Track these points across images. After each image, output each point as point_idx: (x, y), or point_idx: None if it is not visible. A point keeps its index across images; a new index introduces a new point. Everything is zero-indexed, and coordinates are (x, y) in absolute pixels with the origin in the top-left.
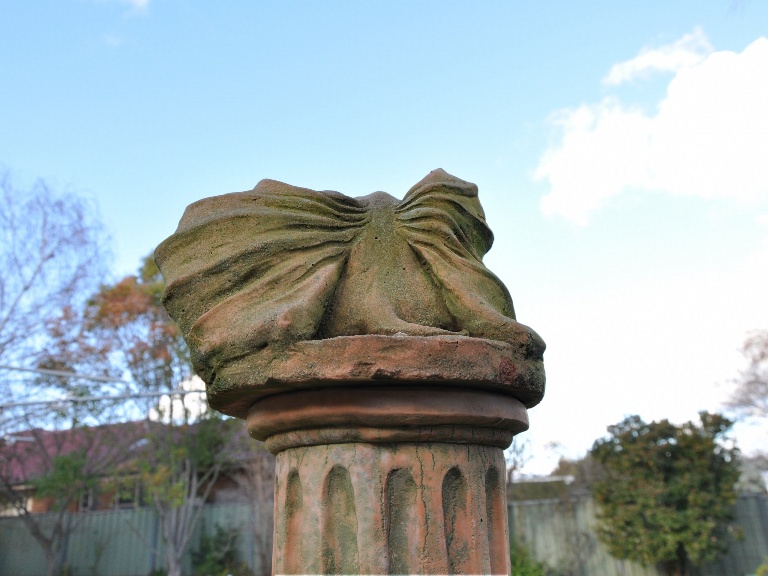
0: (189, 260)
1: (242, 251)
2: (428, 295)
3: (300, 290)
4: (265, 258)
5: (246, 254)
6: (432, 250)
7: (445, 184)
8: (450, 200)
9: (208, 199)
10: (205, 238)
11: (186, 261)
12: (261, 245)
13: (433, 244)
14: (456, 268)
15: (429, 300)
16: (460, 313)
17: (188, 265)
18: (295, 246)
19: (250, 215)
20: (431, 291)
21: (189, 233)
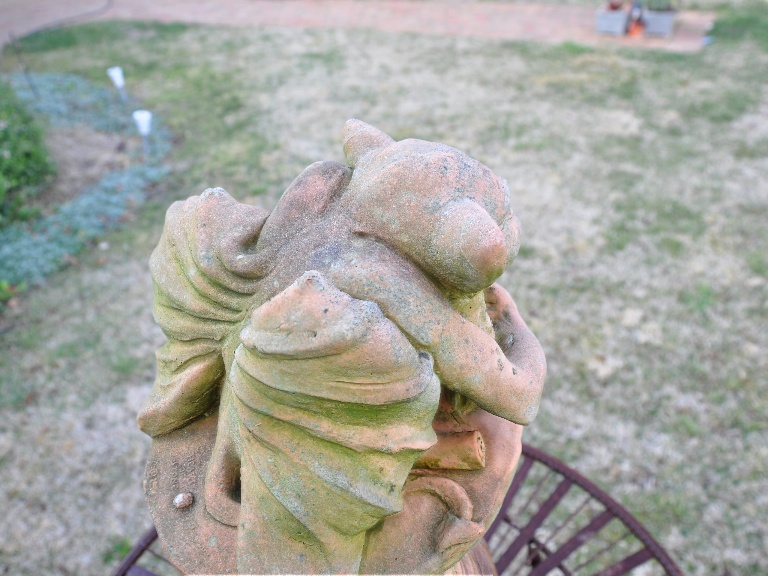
0: None
1: None
2: None
3: (171, 386)
4: None
5: None
6: None
7: (257, 346)
8: (254, 377)
9: None
10: None
11: None
12: None
13: None
14: None
15: None
16: None
17: None
18: (173, 336)
19: None
20: None
21: None
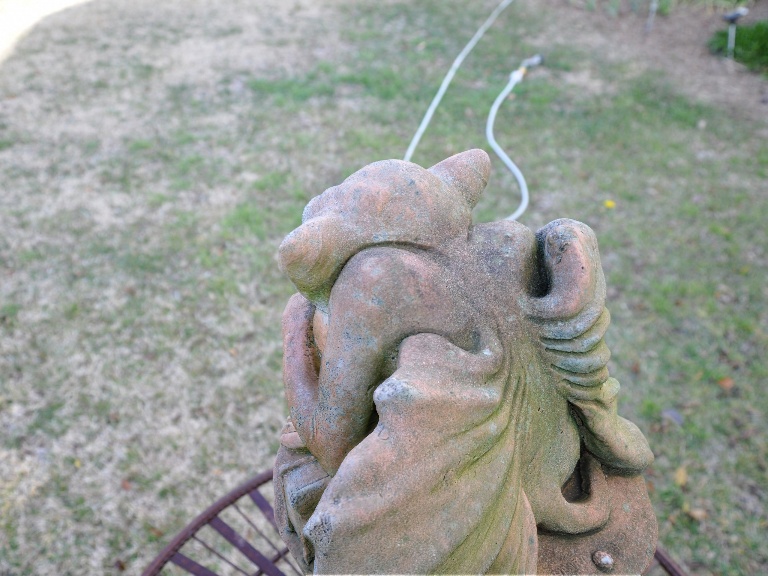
0: None
1: None
2: None
3: (525, 575)
4: None
5: None
6: (591, 403)
7: None
8: None
9: (379, 517)
10: None
11: None
12: None
13: (596, 399)
14: (605, 410)
15: None
16: (602, 456)
17: None
18: None
19: None
20: (578, 440)
21: None
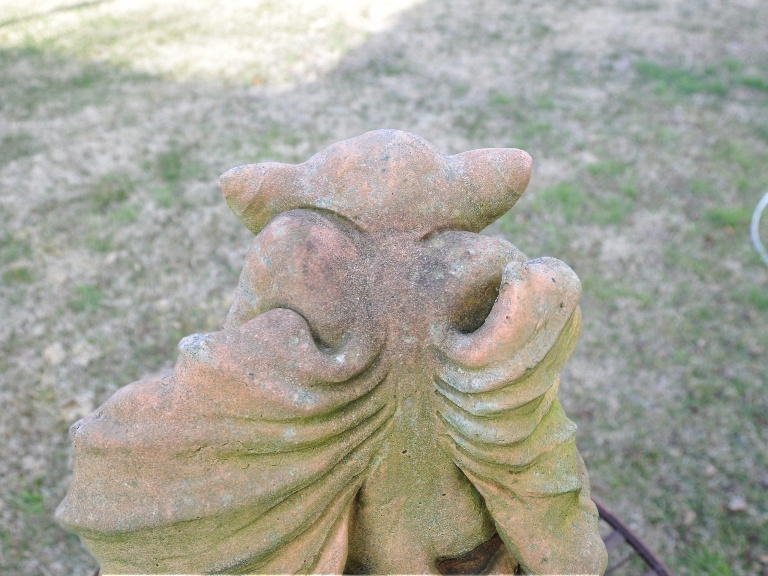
0: (123, 562)
1: (206, 573)
2: (473, 524)
3: None
4: (243, 568)
5: (213, 573)
6: (489, 481)
7: (530, 366)
8: None
9: (111, 448)
10: (137, 544)
11: (118, 561)
12: (234, 565)
13: (493, 479)
14: (519, 501)
15: (473, 530)
16: (512, 553)
17: (124, 569)
18: (285, 543)
19: (202, 517)
20: (478, 517)
21: (107, 535)
